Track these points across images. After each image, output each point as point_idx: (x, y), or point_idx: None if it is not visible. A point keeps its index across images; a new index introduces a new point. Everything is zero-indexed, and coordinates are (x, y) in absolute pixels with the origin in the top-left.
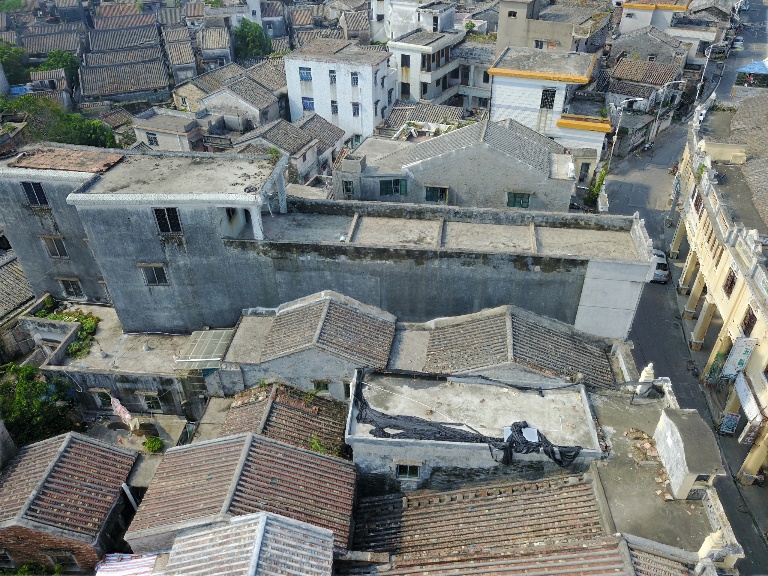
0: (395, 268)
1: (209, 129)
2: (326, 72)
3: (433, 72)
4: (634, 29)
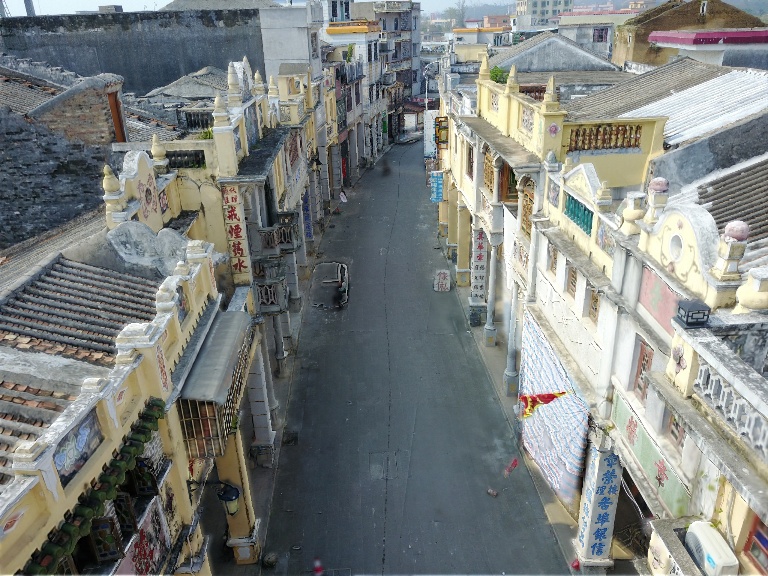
0: (107, 36)
1: None
2: None
3: None
4: None
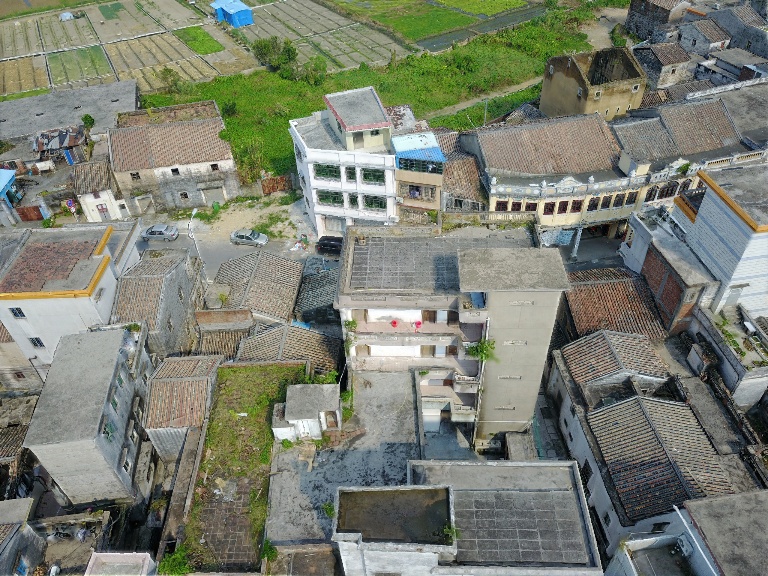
0: None
1: None
2: None
3: None
4: (112, 303)
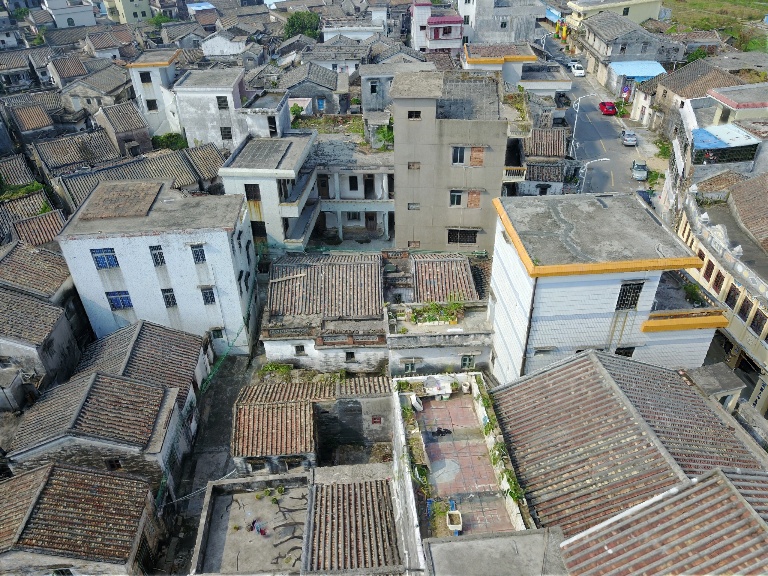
0: None
1: None
2: (144, 250)
3: (298, 202)
4: None
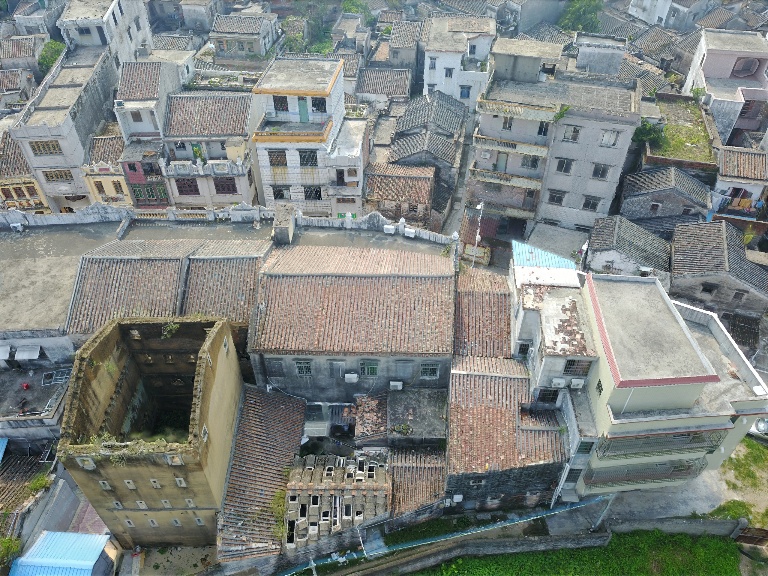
0: None
1: (344, 39)
2: None
3: None
4: None
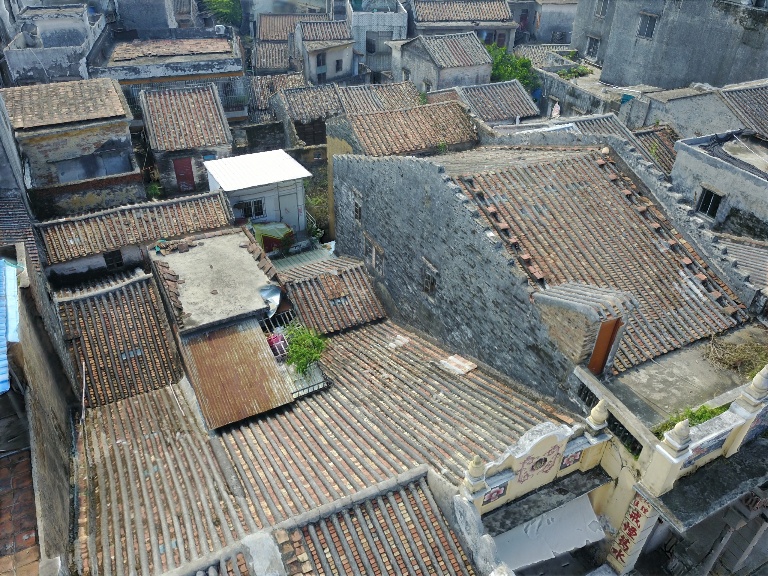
0: None
1: None
2: None
3: None
4: None
